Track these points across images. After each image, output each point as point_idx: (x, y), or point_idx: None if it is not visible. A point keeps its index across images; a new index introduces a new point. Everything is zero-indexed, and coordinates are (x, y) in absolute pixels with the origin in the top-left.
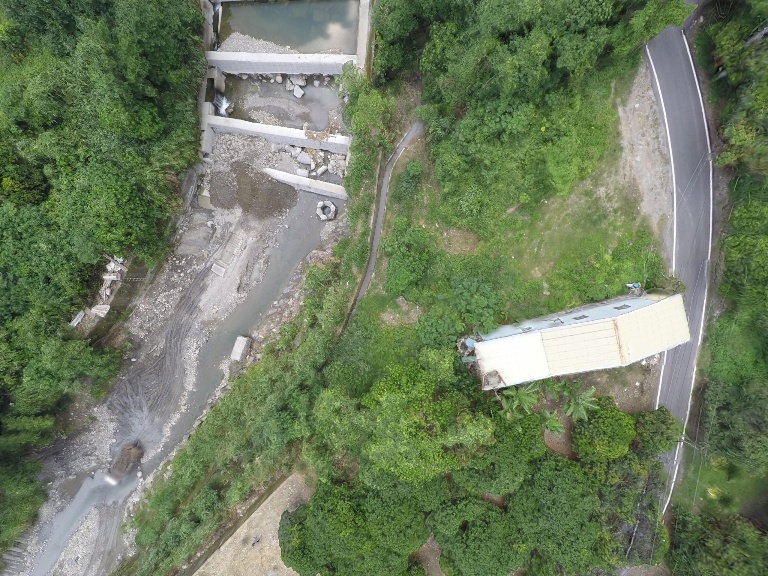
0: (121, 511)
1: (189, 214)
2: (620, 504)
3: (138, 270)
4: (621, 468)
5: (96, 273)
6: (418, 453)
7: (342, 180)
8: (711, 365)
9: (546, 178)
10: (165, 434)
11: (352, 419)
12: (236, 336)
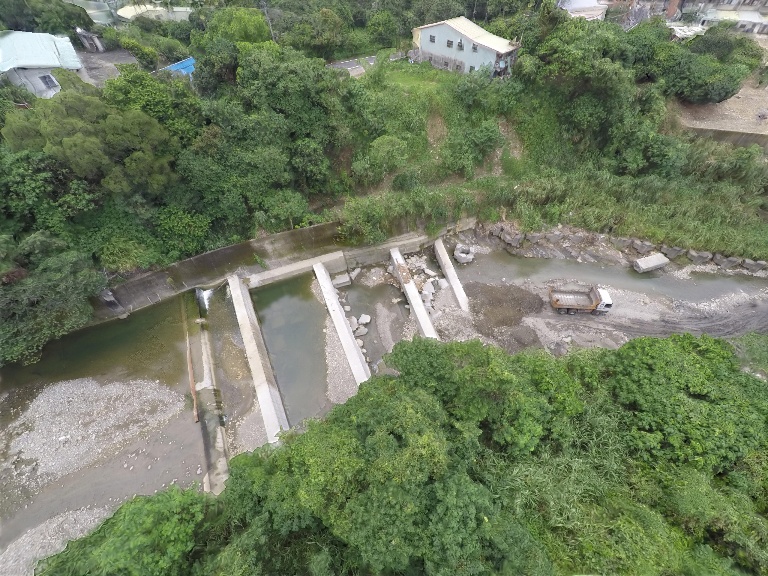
0: None
1: None
2: None
3: None
4: None
5: None
6: None
7: (428, 257)
8: None
9: (383, 72)
10: None
11: None
12: (646, 280)
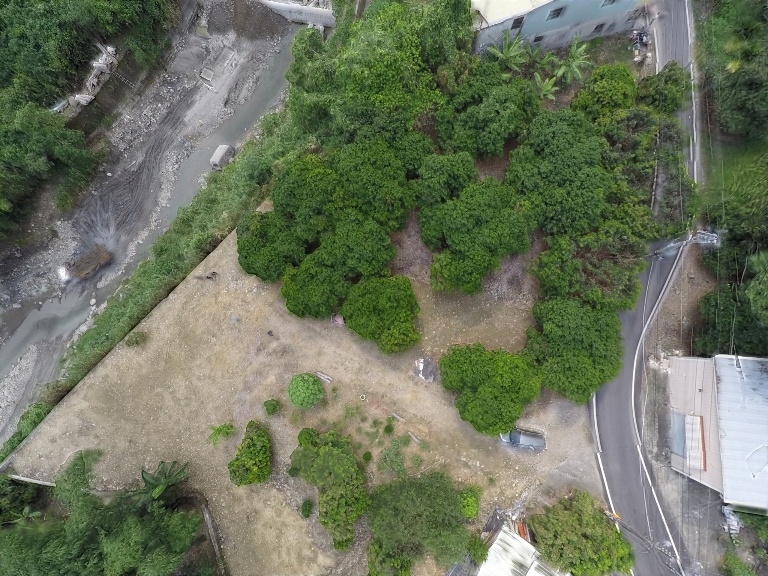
0: (63, 348)
1: (186, 37)
2: (632, 150)
3: (129, 72)
4: None
5: (87, 66)
6: (394, 45)
7: None
8: (707, 63)
9: None
10: (129, 254)
11: (325, 66)
12: None
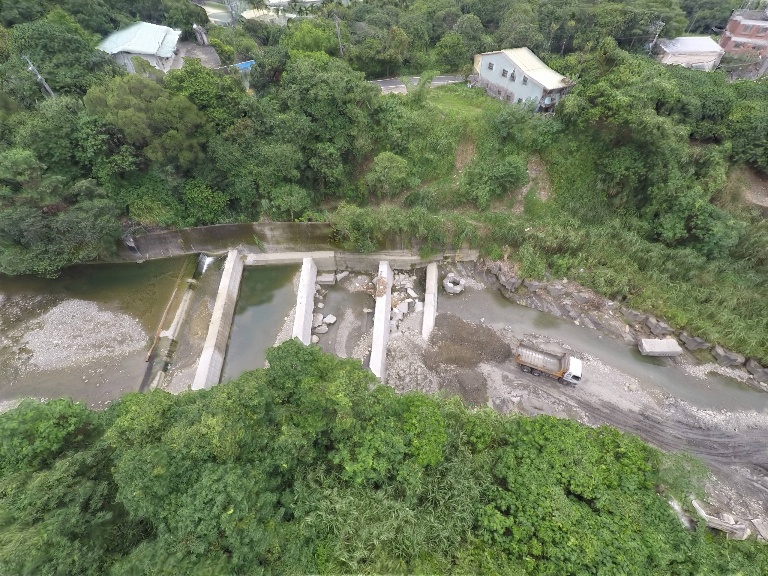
0: None
1: None
2: None
3: None
4: (581, 59)
5: None
6: None
7: (418, 278)
8: None
9: (425, 93)
10: None
11: None
12: (647, 365)
